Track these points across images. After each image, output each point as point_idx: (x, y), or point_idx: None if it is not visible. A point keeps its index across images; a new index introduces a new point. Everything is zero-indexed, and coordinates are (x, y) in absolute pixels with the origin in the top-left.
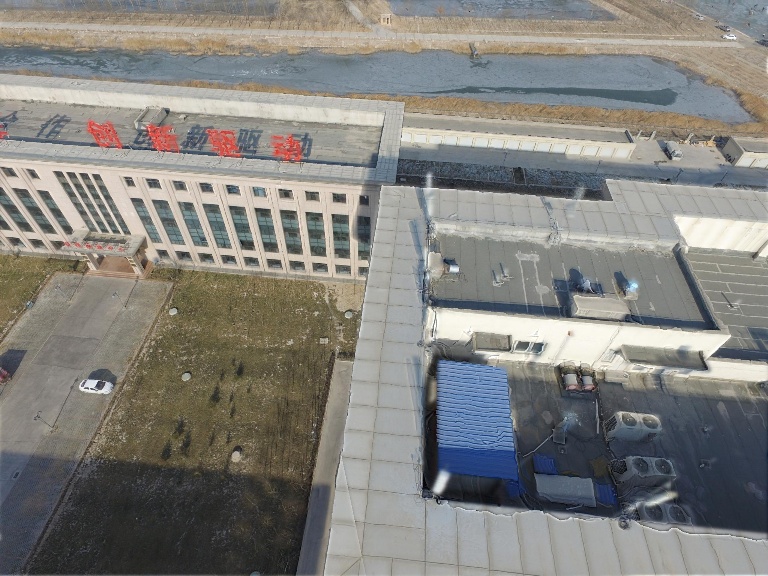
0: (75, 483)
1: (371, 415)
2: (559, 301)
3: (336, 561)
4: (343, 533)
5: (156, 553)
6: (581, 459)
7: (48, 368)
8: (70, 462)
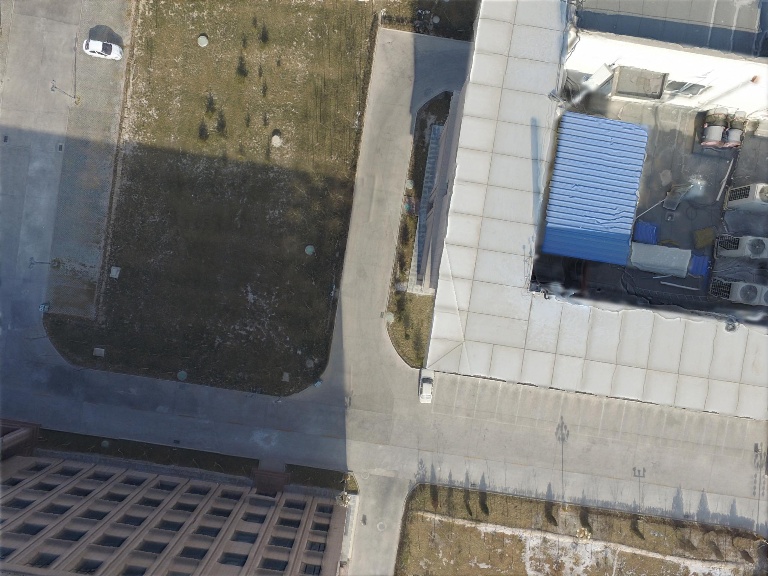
0: (122, 159)
1: (480, 195)
2: (761, 21)
3: (439, 344)
4: (446, 320)
5: (219, 226)
6: (688, 230)
7: (36, 21)
8: (108, 137)
